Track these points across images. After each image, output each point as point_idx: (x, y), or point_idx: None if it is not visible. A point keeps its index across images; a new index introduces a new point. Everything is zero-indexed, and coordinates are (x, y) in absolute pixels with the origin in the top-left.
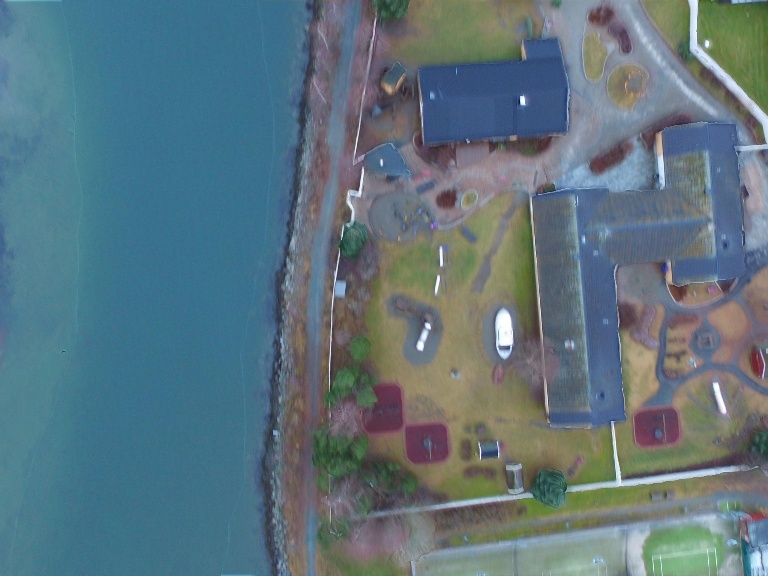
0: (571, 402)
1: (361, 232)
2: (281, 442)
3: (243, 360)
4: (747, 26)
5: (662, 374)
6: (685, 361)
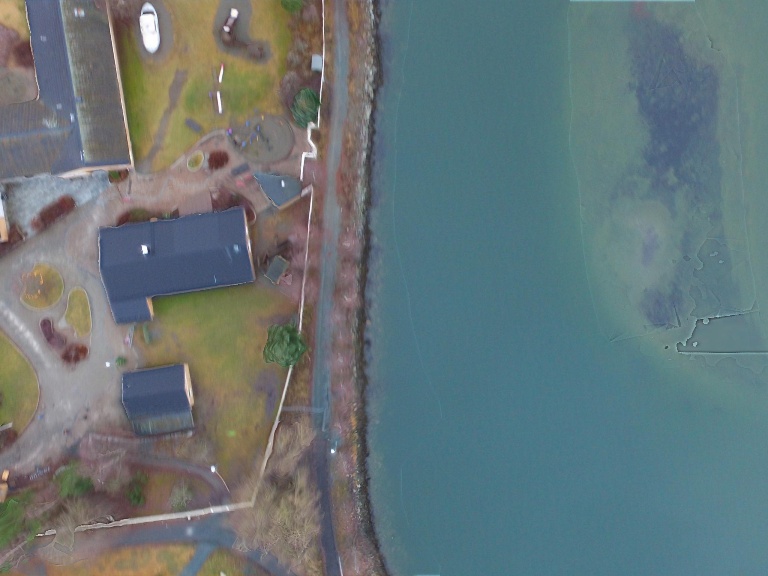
0: None
1: (298, 111)
2: None
3: None
4: None
5: None
6: None
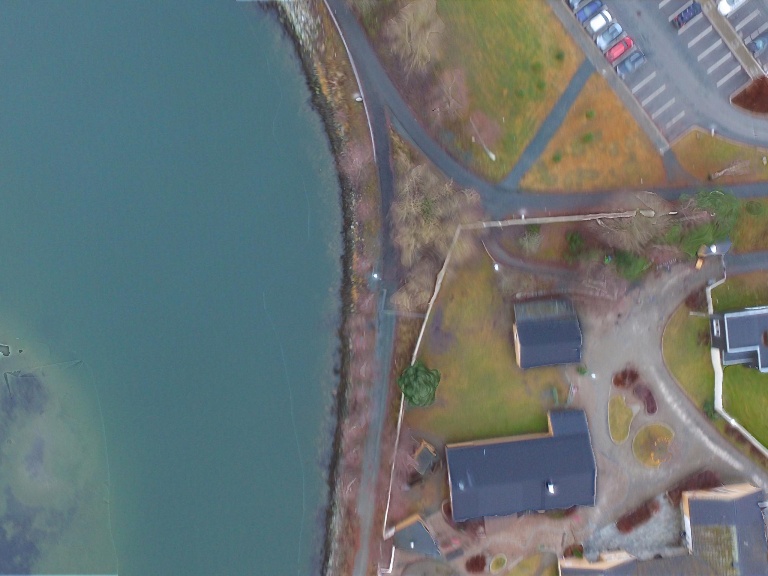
0: None
1: None
2: None
3: None
4: None
5: None
6: None
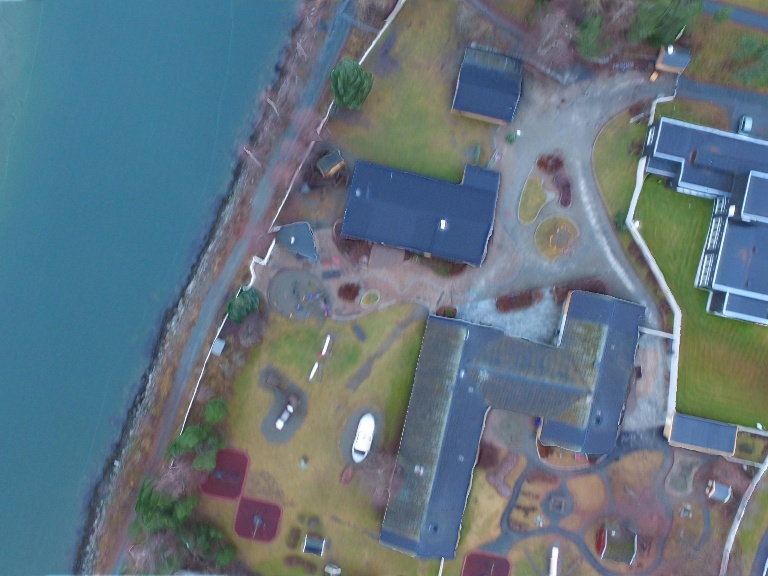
0: (404, 526)
1: (250, 301)
2: (119, 474)
3: (109, 383)
4: (686, 216)
5: (506, 523)
6: (532, 517)
